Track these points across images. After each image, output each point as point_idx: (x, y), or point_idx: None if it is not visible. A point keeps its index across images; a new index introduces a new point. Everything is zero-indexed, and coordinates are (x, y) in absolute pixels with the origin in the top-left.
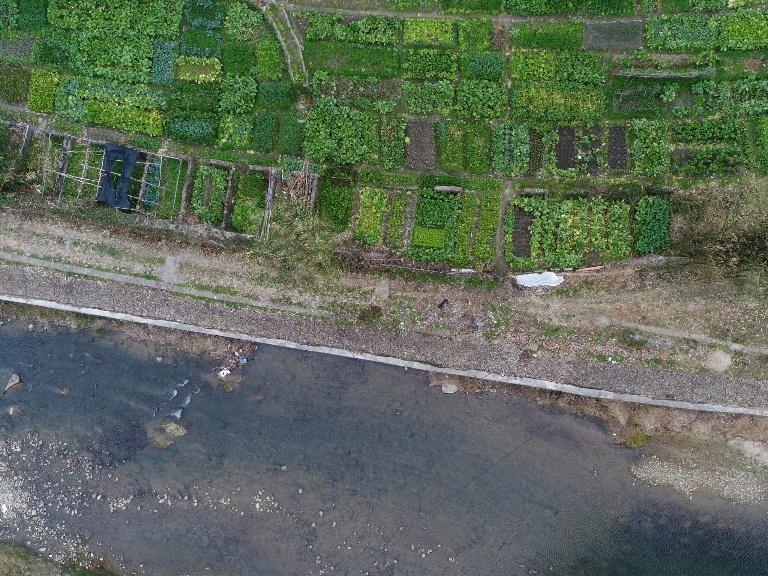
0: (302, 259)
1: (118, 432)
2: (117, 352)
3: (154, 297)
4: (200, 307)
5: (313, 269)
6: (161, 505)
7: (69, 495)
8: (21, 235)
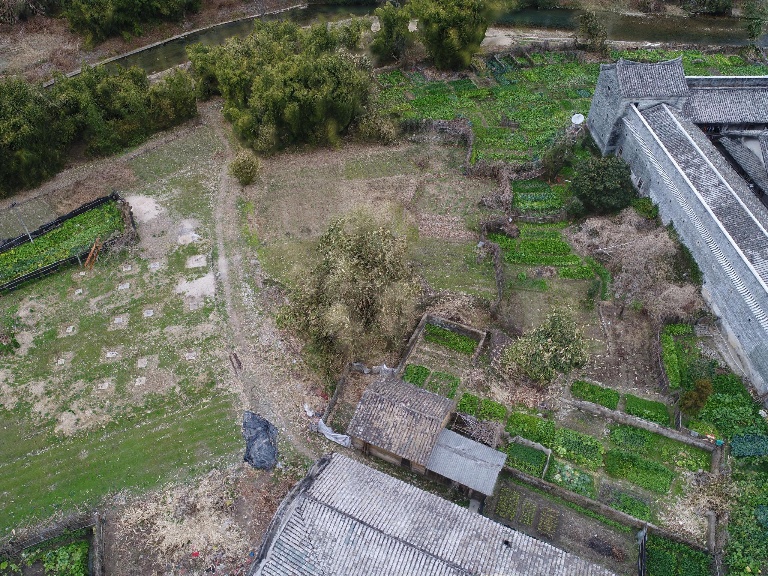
0: None
1: None
2: None
3: None
4: None
5: None
6: None
7: None
8: None
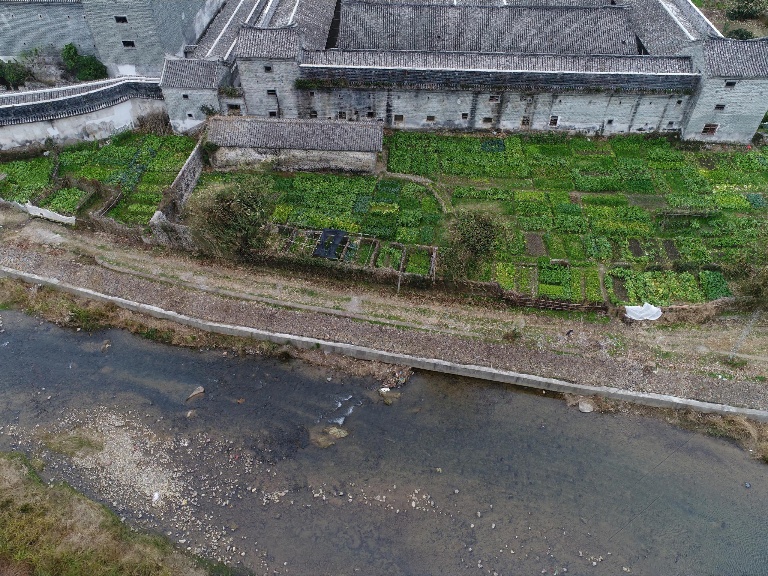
0: (456, 299)
1: (283, 434)
2: (293, 374)
3: (338, 323)
4: (374, 330)
5: (464, 307)
6: (315, 500)
7: (224, 487)
8: (245, 282)
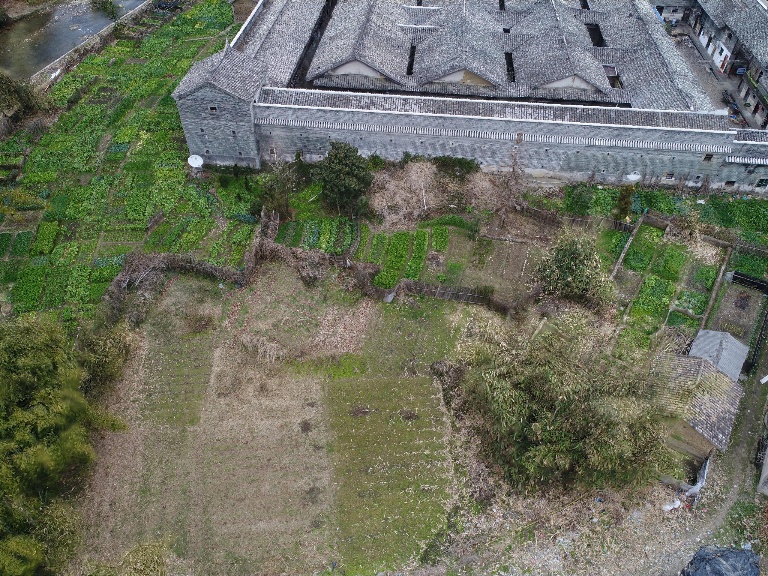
0: None
1: None
2: None
3: None
4: None
5: None
6: None
7: None
8: None
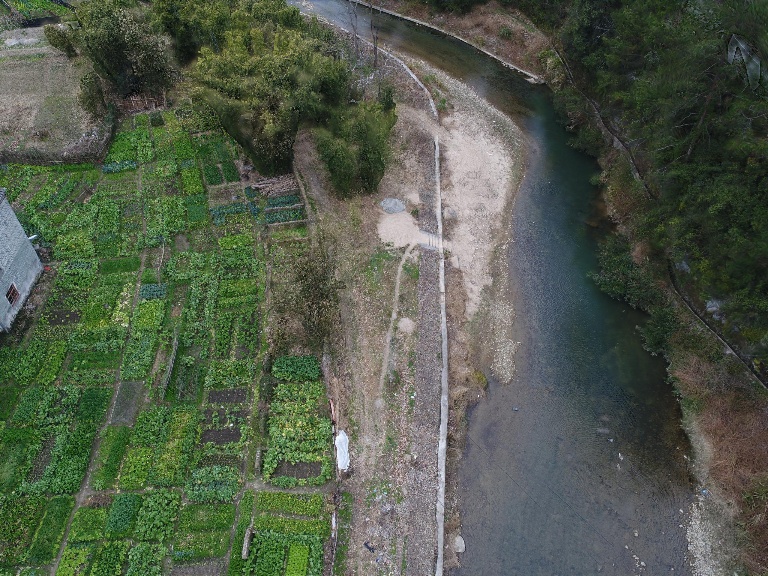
0: None
1: None
2: None
3: None
4: None
5: None
6: None
7: None
8: None
